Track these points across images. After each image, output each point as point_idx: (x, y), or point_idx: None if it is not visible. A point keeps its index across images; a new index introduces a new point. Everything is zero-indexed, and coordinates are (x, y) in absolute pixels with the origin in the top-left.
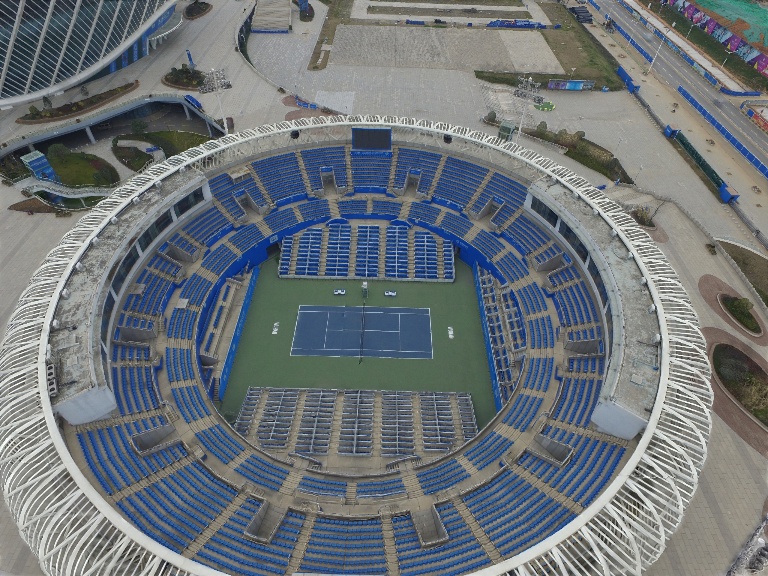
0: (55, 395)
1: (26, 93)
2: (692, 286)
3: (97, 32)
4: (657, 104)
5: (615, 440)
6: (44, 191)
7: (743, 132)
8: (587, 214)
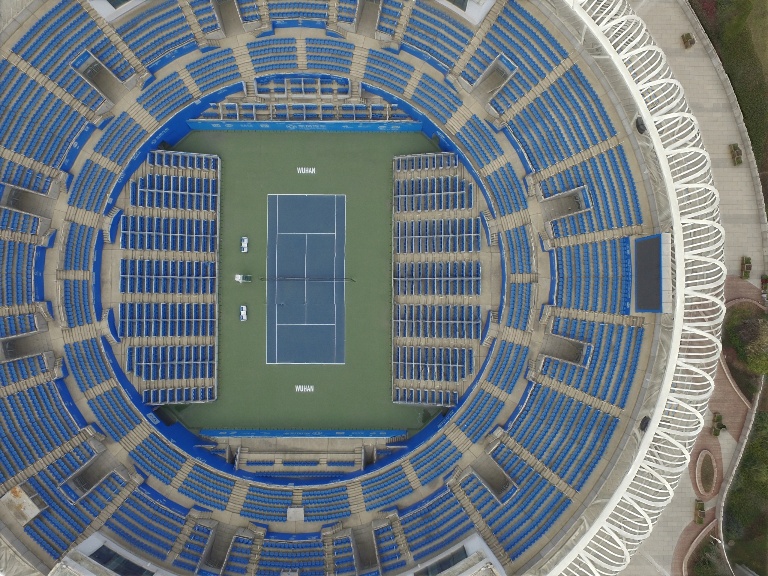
0: None
1: None
2: None
3: None
4: None
5: (498, 7)
6: None
7: None
8: None
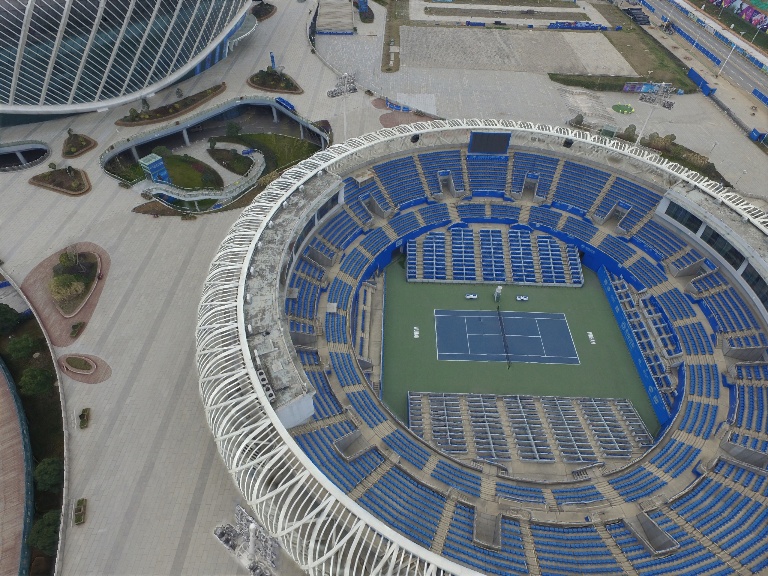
0: (273, 401)
1: (121, 95)
2: None
3: (190, 34)
4: (735, 107)
5: None
6: (161, 194)
7: None
8: (736, 220)
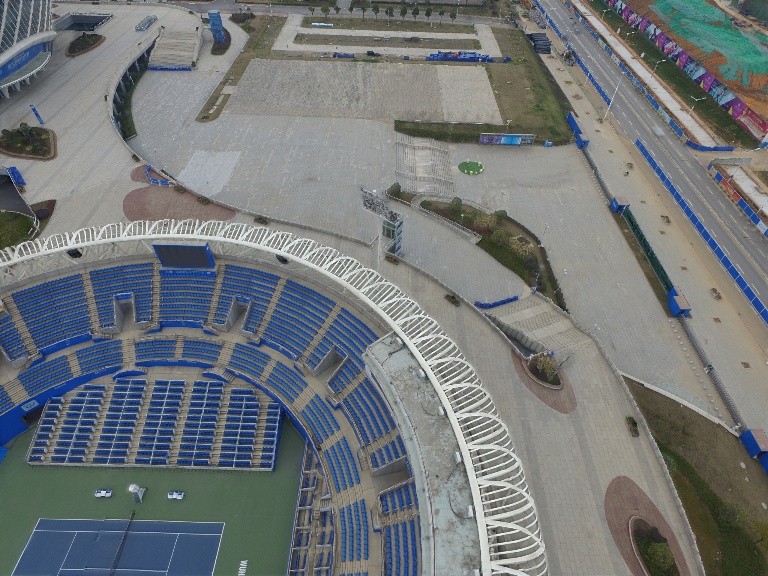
0: None
1: None
2: (595, 501)
3: None
4: (608, 164)
5: None
6: None
7: (707, 204)
8: (430, 413)
